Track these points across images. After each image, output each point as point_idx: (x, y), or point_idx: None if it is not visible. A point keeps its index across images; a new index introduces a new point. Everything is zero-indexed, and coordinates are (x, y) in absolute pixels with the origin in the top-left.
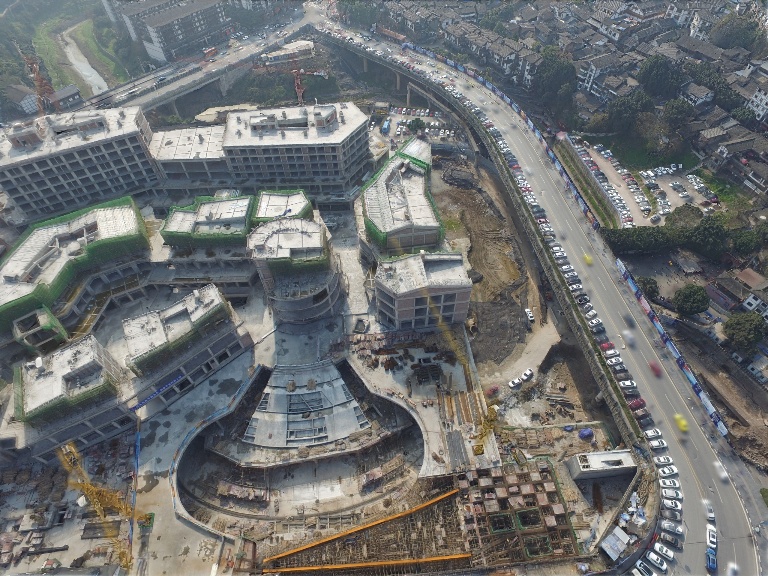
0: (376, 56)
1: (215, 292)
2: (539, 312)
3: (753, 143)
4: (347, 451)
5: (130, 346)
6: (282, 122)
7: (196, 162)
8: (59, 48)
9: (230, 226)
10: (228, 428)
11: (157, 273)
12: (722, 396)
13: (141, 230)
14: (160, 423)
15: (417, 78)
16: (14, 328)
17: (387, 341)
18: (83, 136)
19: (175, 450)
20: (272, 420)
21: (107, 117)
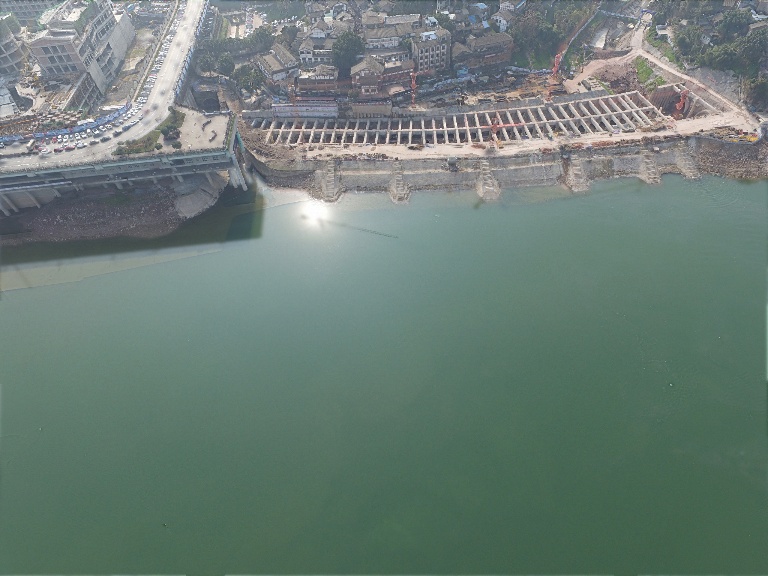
0: None
1: None
2: None
3: None
4: (2, 120)
5: None
6: None
7: None
8: None
9: None
10: None
11: None
12: (229, 108)
13: None
14: None
15: None
16: None
17: None
18: None
19: None
20: None
21: None
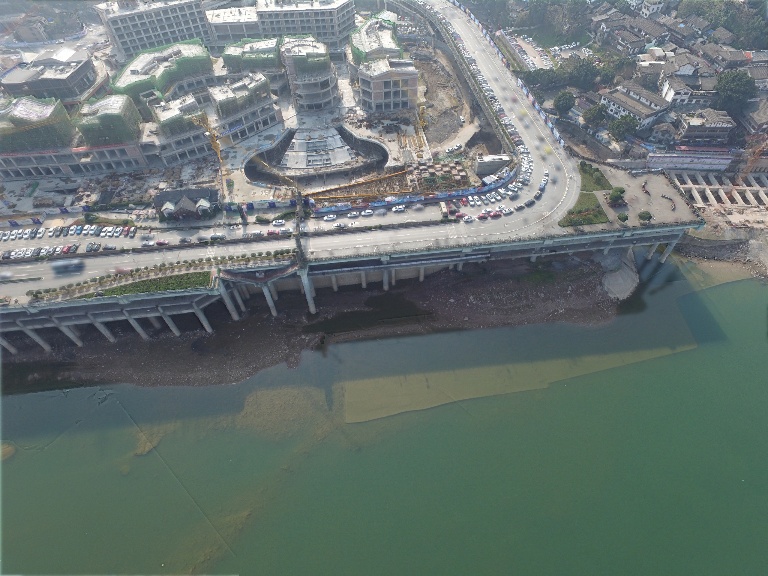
0: None
1: (262, 75)
2: (469, 118)
3: (624, 21)
4: (343, 168)
5: (215, 97)
6: (295, 0)
7: (238, 25)
8: None
9: (265, 54)
10: (270, 162)
11: None
12: None
13: None
14: (231, 151)
15: None
16: (141, 96)
17: (367, 115)
18: (165, 2)
19: None
20: (297, 154)
21: None
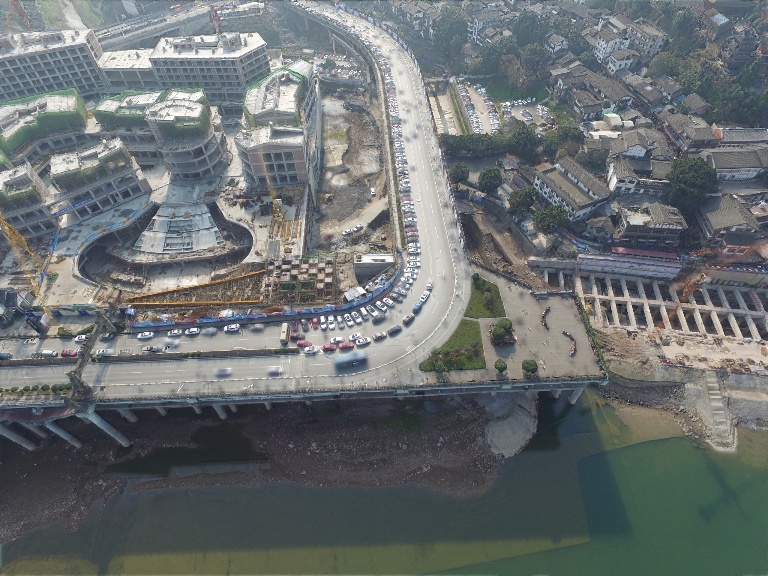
0: (311, 14)
1: (118, 142)
2: (381, 190)
3: (585, 78)
4: (204, 256)
5: (52, 168)
6: (200, 44)
7: (131, 71)
8: (59, 8)
9: (144, 110)
10: (125, 242)
11: (90, 144)
12: (500, 246)
13: (79, 110)
14: (74, 230)
15: (339, 30)
16: None
17: (246, 190)
18: (45, 45)
19: (80, 243)
20: (155, 236)
21: (66, 35)
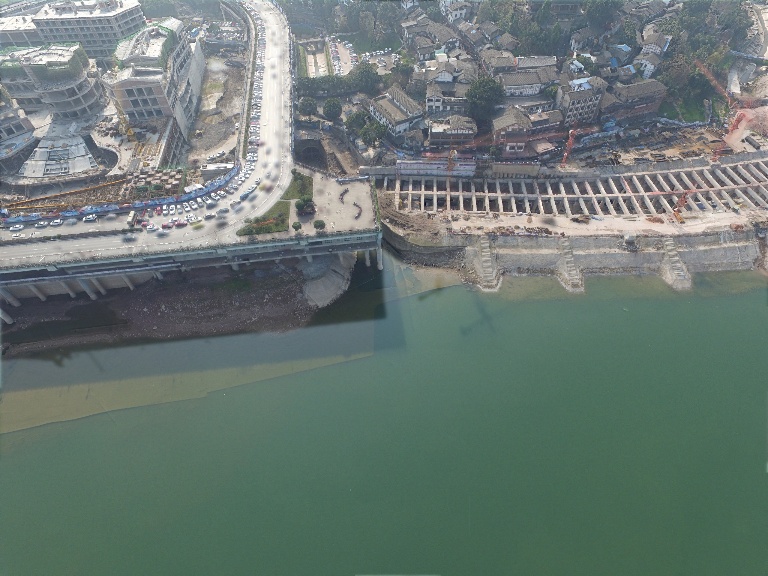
0: None
1: None
2: None
3: (427, 27)
4: (79, 177)
5: None
6: (80, 8)
7: (18, 33)
8: None
9: None
10: (10, 171)
11: None
12: (340, 162)
13: None
14: None
15: None
16: None
17: (116, 123)
18: None
19: None
20: (36, 163)
21: None
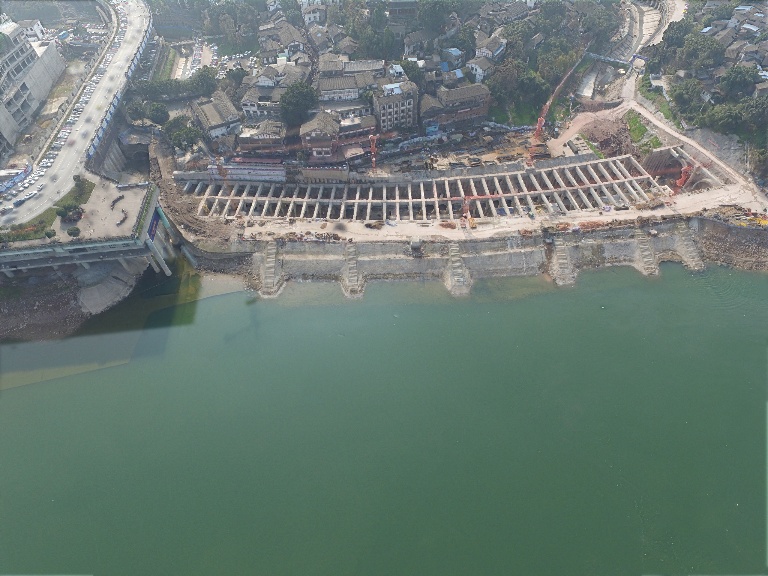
0: None
1: None
2: None
3: (280, 30)
4: None
5: None
6: None
7: None
8: None
9: None
10: None
11: None
12: None
13: None
14: None
15: (101, 2)
16: None
17: None
18: None
19: None
20: None
21: None
